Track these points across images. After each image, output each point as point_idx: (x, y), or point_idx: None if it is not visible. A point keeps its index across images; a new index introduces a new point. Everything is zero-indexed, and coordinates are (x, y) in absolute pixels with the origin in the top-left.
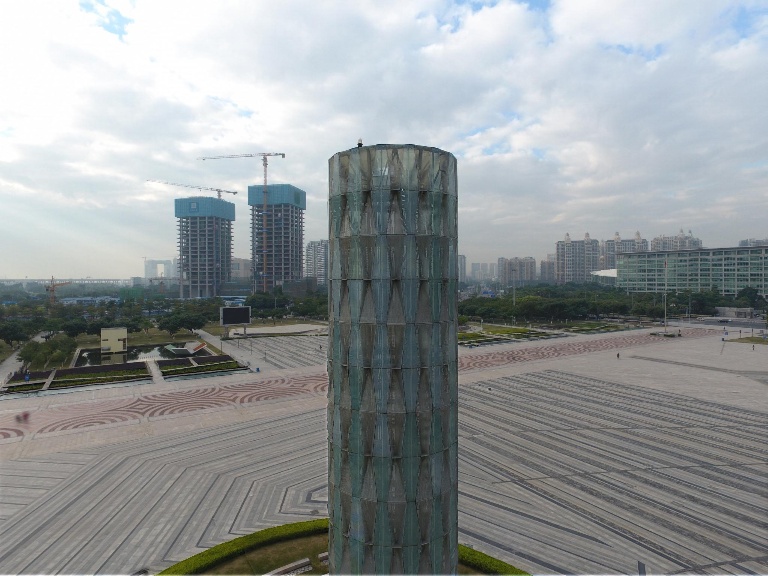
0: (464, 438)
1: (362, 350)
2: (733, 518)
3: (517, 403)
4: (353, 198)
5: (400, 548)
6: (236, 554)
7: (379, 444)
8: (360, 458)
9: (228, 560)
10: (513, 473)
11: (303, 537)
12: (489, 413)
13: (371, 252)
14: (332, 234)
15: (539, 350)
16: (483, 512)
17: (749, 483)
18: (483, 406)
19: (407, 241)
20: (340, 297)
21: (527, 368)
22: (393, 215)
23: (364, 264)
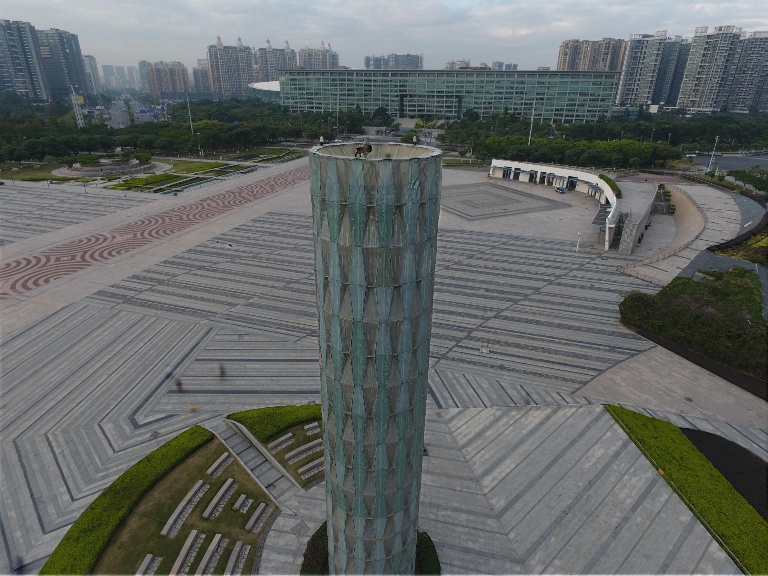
0: (242, 306)
1: (390, 342)
2: (445, 315)
3: (265, 256)
4: (382, 210)
5: (411, 459)
6: (125, 516)
7: (400, 404)
8: (385, 418)
9: (120, 526)
10: (304, 327)
11: (178, 465)
12: (247, 273)
13: (399, 260)
14: (346, 240)
15: (247, 189)
16: (304, 370)
17: (442, 286)
18: (237, 266)
19: (426, 245)
20: (365, 302)
21: (249, 213)
22: (418, 225)
23: (393, 272)
